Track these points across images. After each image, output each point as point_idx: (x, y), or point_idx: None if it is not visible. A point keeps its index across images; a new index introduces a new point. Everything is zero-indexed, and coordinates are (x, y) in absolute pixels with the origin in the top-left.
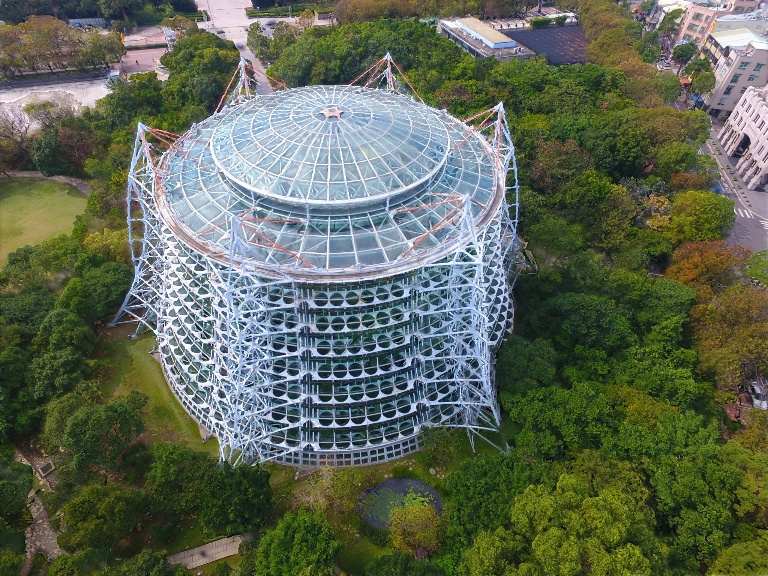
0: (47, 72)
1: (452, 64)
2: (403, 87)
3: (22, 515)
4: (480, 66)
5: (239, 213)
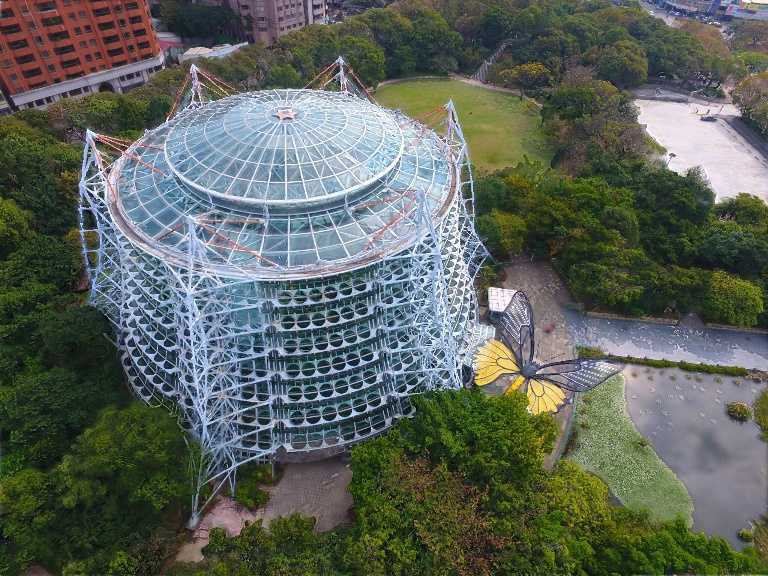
0: None
1: None
2: None
3: None
4: None
5: None
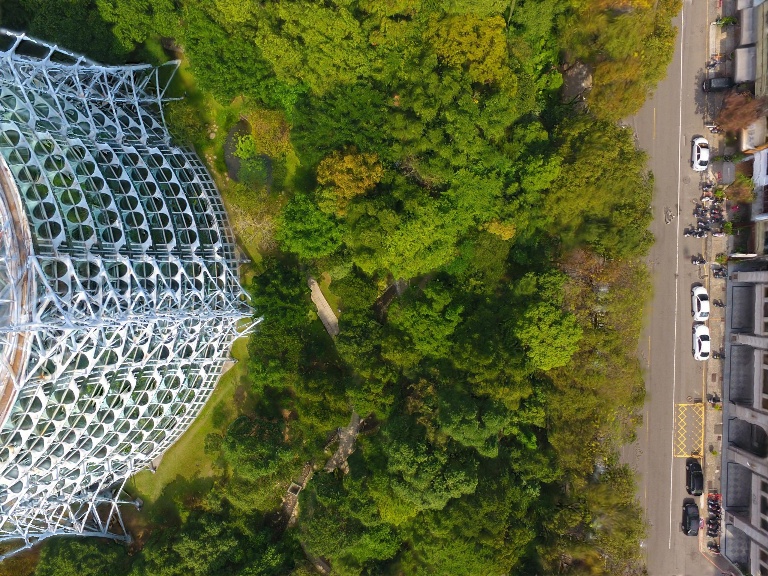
0: None
1: None
2: None
3: None
4: None
5: None
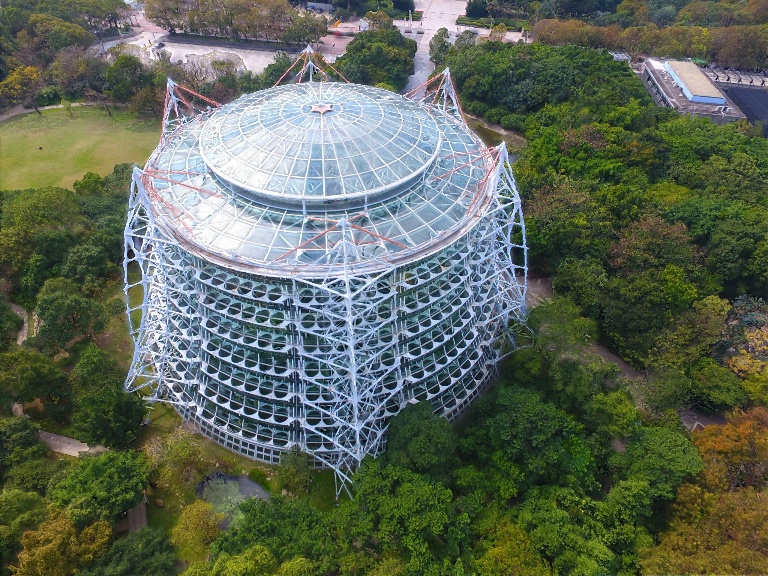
0: (264, 40)
1: (611, 106)
2: (550, 119)
3: (7, 352)
4: (651, 116)
5: (195, 175)
